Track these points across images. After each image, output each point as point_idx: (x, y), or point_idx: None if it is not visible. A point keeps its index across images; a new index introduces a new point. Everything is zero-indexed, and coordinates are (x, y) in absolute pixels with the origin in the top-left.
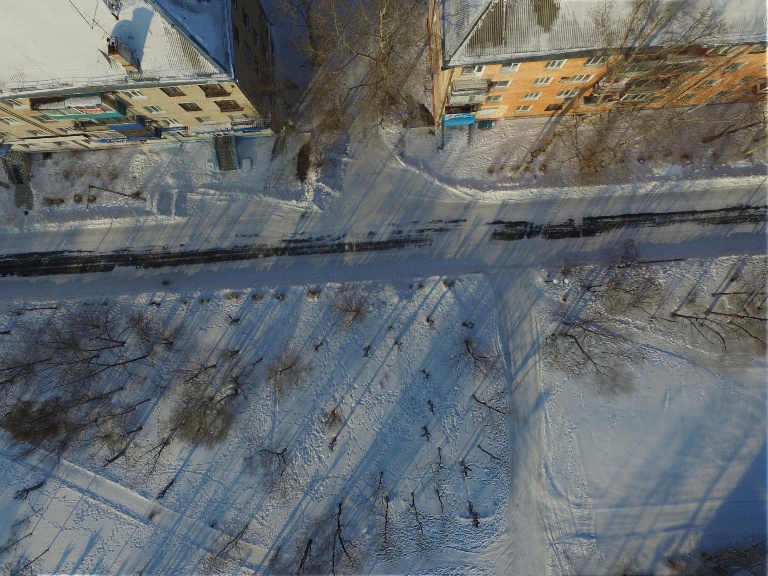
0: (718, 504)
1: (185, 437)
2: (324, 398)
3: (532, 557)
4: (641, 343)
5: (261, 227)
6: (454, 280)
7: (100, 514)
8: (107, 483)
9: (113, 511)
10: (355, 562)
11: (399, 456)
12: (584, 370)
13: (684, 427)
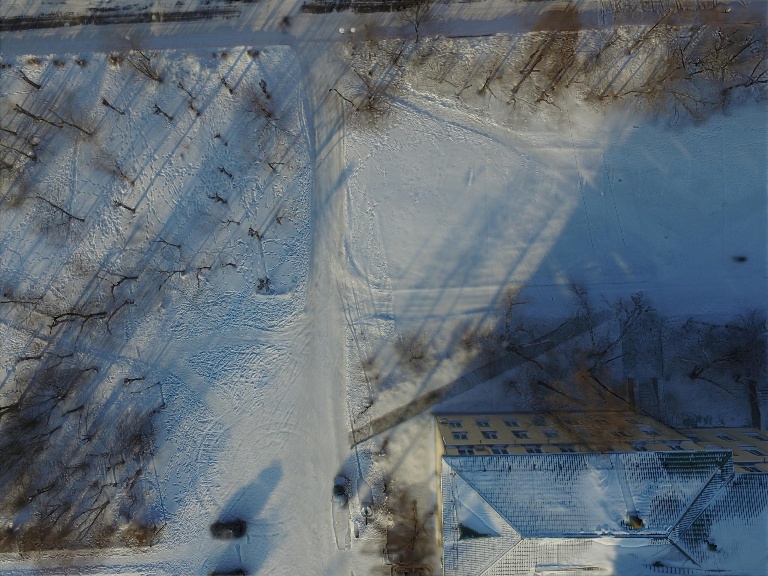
0: None
1: None
2: (124, 168)
3: (330, 338)
4: (447, 120)
5: None
6: (259, 51)
7: None
8: None
9: None
10: (149, 337)
11: (197, 230)
12: (388, 147)
13: (486, 207)
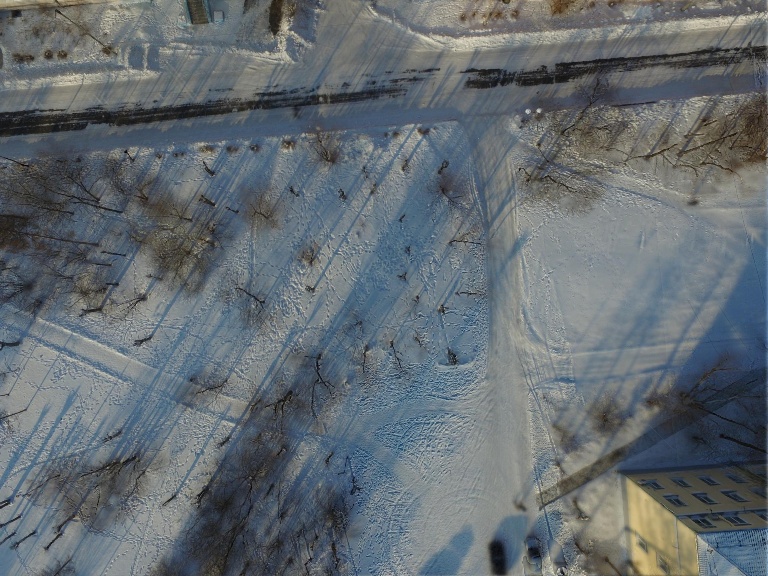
0: (694, 344)
1: (162, 292)
2: (301, 249)
3: (512, 403)
4: (615, 186)
5: (234, 80)
6: (429, 128)
7: (78, 372)
8: (84, 341)
9: (91, 369)
10: (336, 413)
11: (377, 305)
12: (560, 215)
13: (659, 268)
